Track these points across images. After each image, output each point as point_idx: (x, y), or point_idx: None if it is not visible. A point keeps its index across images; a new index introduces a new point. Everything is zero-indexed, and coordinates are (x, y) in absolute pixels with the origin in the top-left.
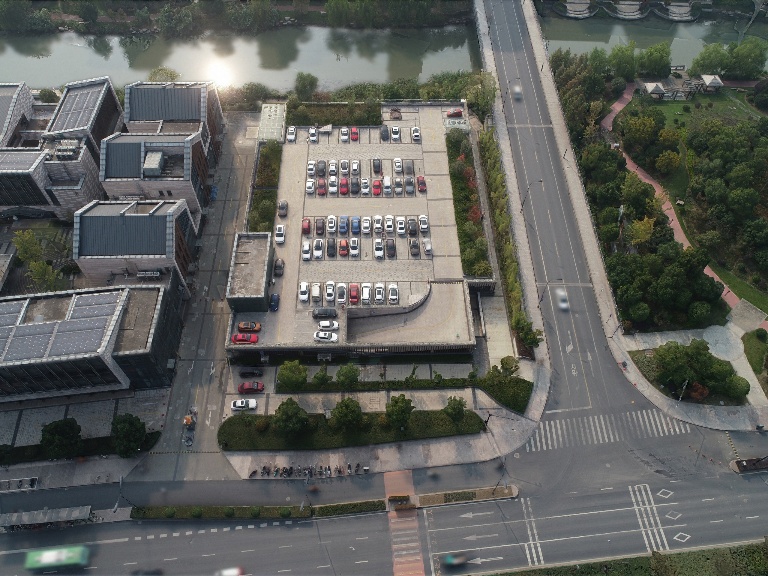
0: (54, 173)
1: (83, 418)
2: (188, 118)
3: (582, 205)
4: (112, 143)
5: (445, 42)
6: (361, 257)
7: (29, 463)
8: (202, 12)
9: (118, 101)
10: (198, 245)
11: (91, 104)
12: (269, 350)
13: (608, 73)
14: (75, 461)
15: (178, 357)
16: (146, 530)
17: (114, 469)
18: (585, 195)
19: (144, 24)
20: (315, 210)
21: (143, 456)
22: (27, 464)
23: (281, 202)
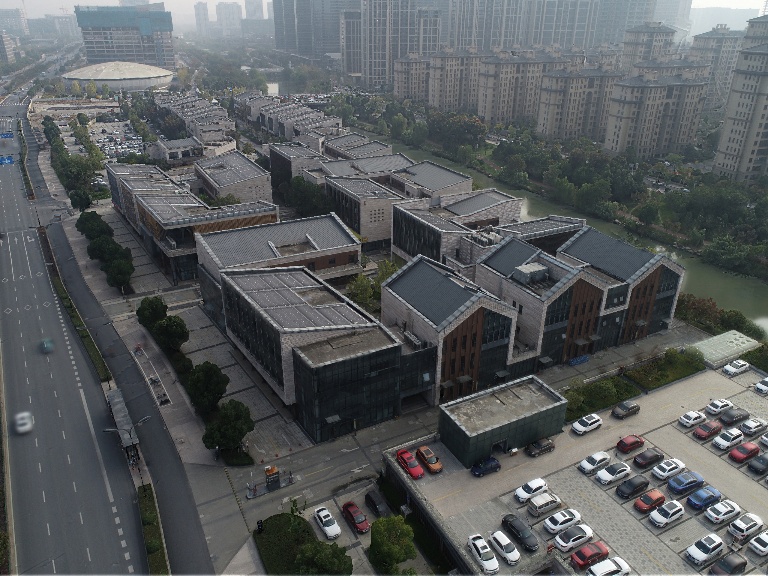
0: (463, 251)
1: (246, 401)
2: (617, 274)
3: None
4: (516, 241)
5: None
6: (663, 534)
7: (185, 391)
8: (764, 256)
9: None
10: (499, 374)
11: (548, 228)
12: (415, 500)
13: None
14: (196, 418)
15: (354, 432)
16: (126, 512)
17: (196, 449)
18: None
19: (692, 244)
20: (666, 442)
21: (219, 464)
22: (184, 391)
23: (629, 401)
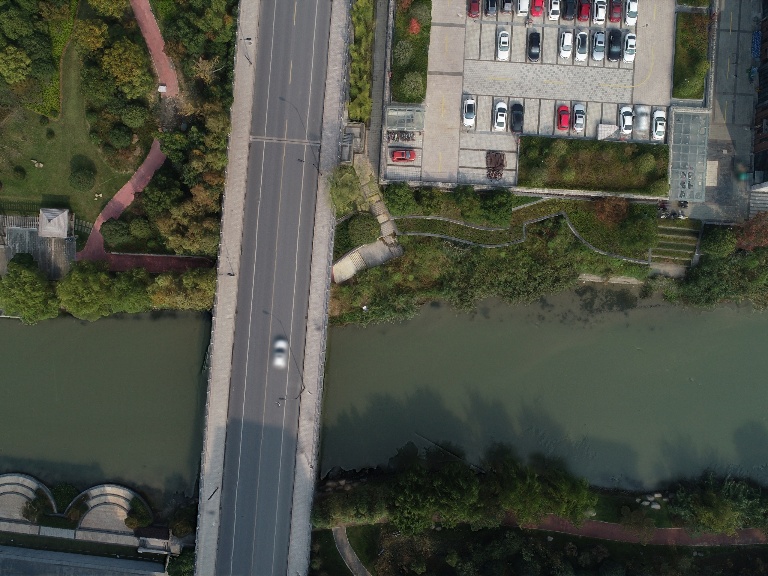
0: None
1: None
2: None
3: None
4: None
5: None
6: None
7: None
8: None
9: None
10: None
11: None
12: None
13: None
14: None
15: None
16: None
17: None
18: None
19: None
20: None
21: None
22: None
23: None
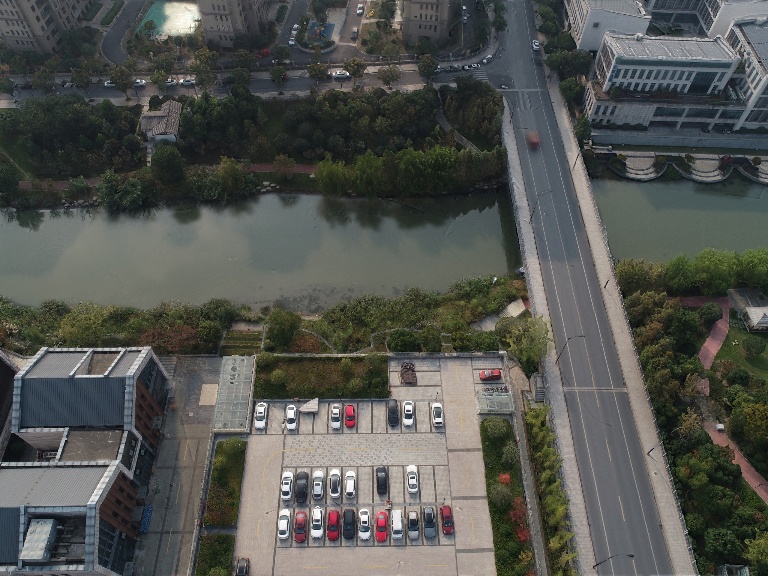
0: None
1: None
2: (106, 423)
3: (683, 552)
4: None
5: (469, 205)
6: None
7: None
8: (155, 179)
9: (16, 368)
10: None
11: None
12: None
13: (693, 284)
14: None
15: None
16: None
17: None
18: (686, 534)
19: (80, 194)
20: (290, 574)
21: None
22: None
23: (239, 566)
